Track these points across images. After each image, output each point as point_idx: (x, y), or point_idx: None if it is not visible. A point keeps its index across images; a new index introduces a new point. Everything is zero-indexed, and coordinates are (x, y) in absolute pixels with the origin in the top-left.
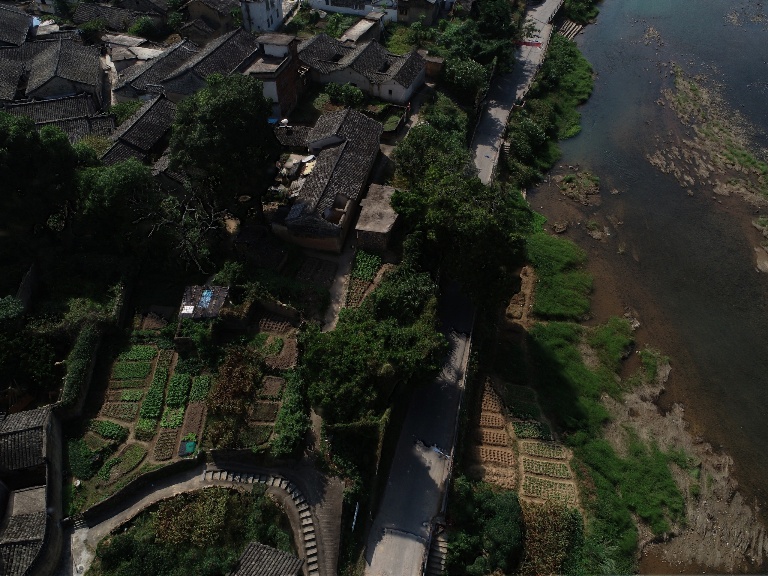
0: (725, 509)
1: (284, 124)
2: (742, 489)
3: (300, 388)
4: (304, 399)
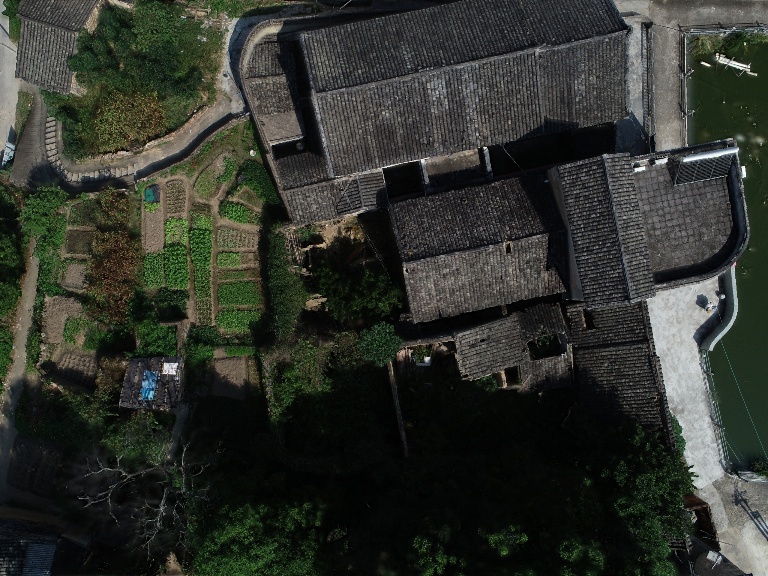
0: None
1: None
2: None
3: (40, 272)
4: (40, 263)
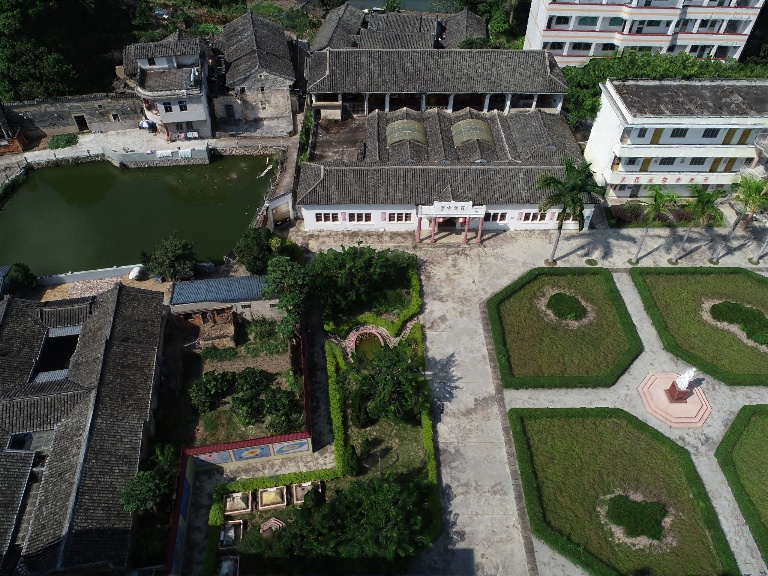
0: (278, 3)
1: None
2: (272, 0)
3: None
4: None
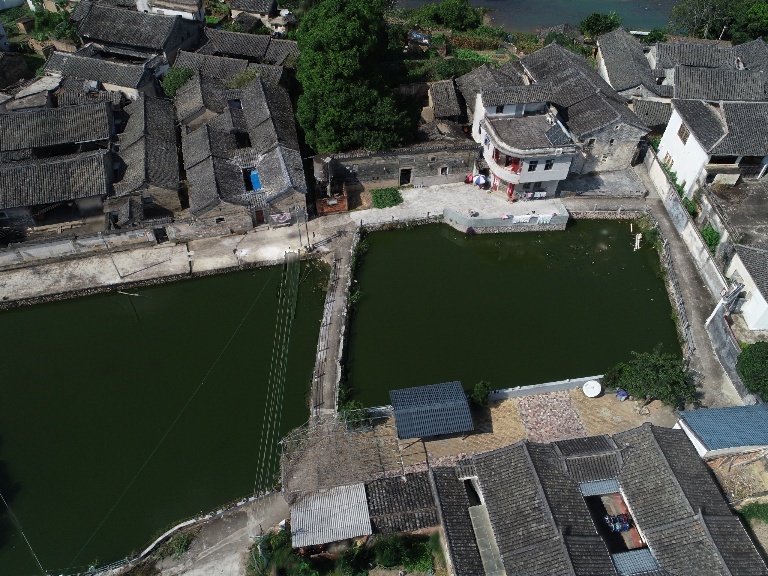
0: None
1: (233, 20)
2: None
3: None
4: None
